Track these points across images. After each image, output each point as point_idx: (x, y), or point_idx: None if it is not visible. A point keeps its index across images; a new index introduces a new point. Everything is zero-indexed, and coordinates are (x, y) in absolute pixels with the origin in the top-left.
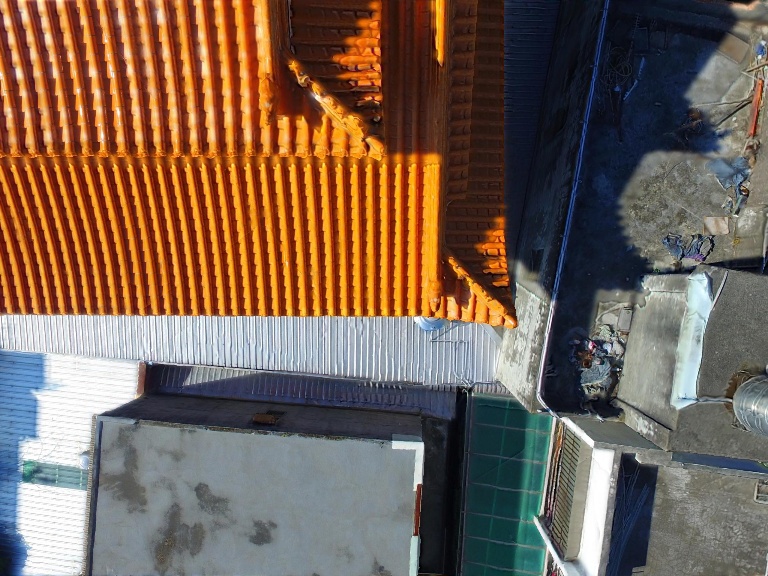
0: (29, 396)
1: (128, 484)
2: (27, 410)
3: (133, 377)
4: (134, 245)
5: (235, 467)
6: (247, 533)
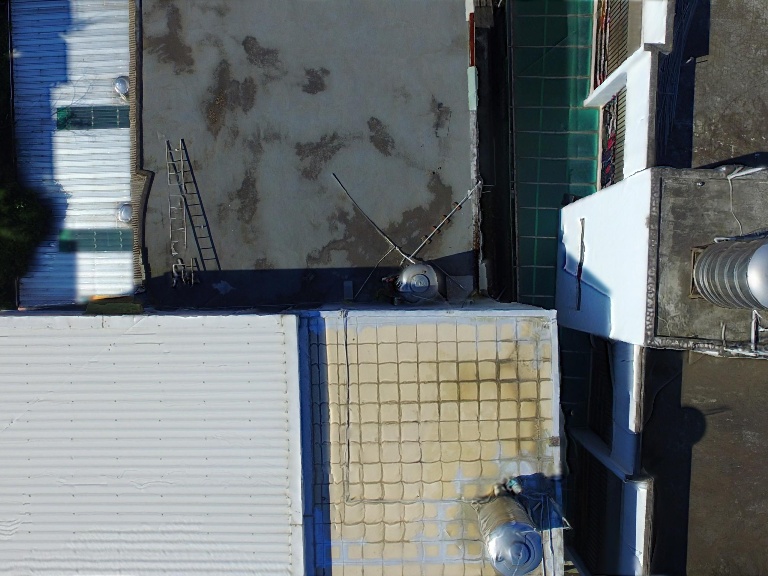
0: (57, 40)
1: (173, 45)
2: (56, 55)
3: None
4: None
5: (282, 16)
6: (300, 83)
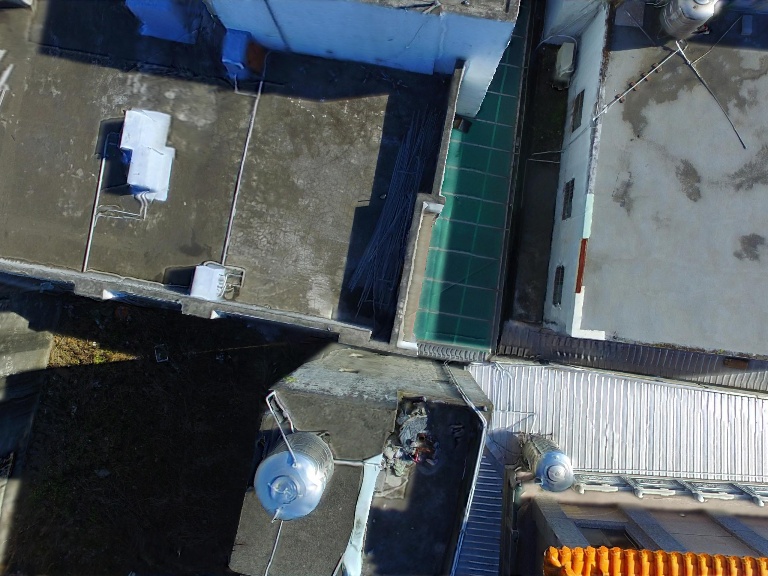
0: None
1: None
2: None
3: None
4: None
5: None
6: (767, 248)
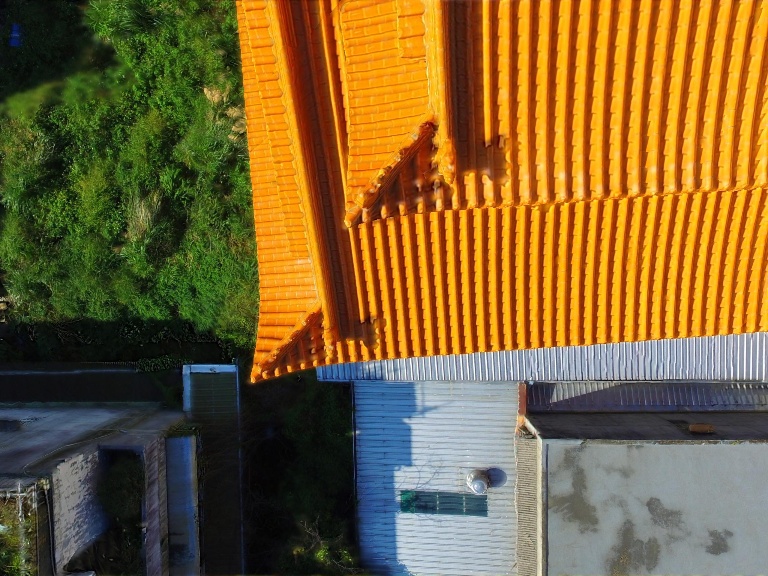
0: (402, 426)
1: (578, 505)
2: (401, 440)
3: (513, 398)
4: (746, 265)
5: (686, 479)
6: (703, 544)
